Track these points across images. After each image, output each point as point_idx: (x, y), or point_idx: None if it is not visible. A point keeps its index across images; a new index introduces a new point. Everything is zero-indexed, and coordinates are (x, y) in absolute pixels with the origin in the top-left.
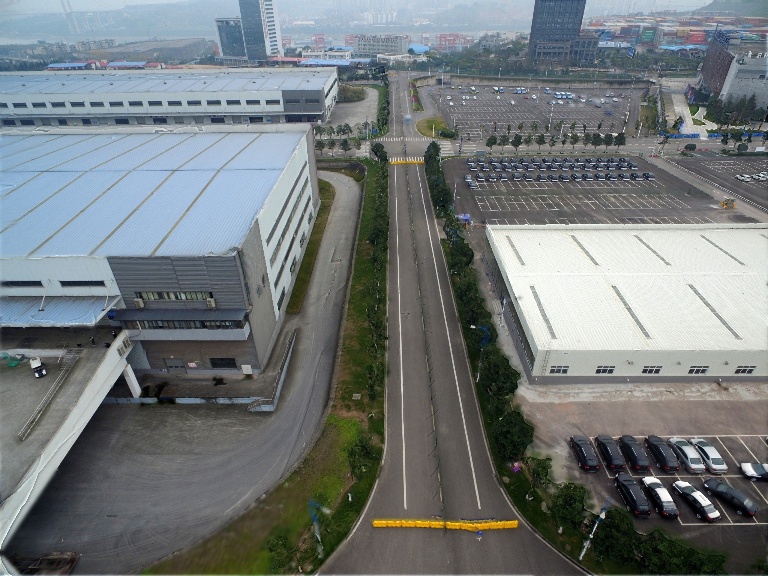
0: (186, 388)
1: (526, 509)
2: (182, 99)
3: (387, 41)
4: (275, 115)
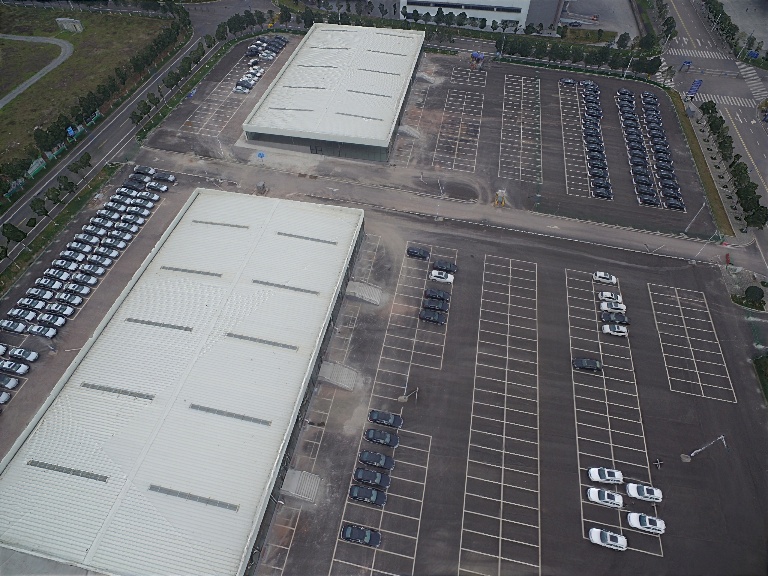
0: (369, 8)
1: None
2: None
3: None
4: None
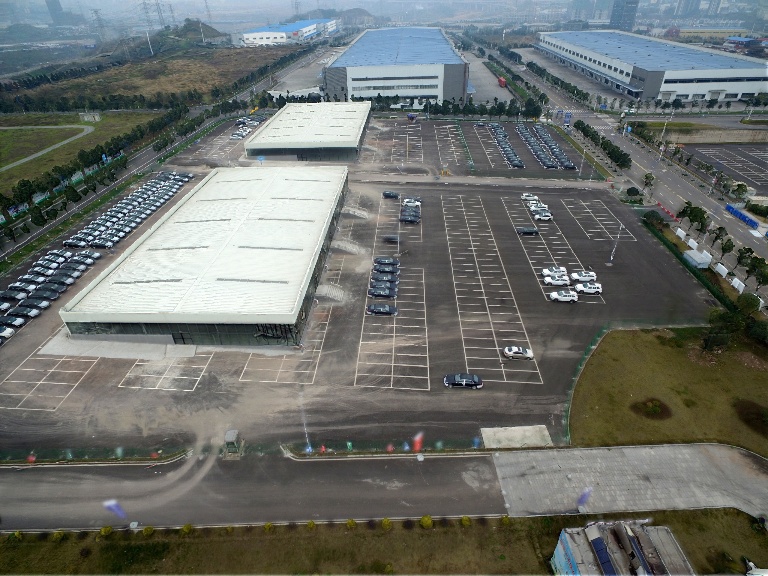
0: None
1: (253, 114)
2: None
3: None
4: None
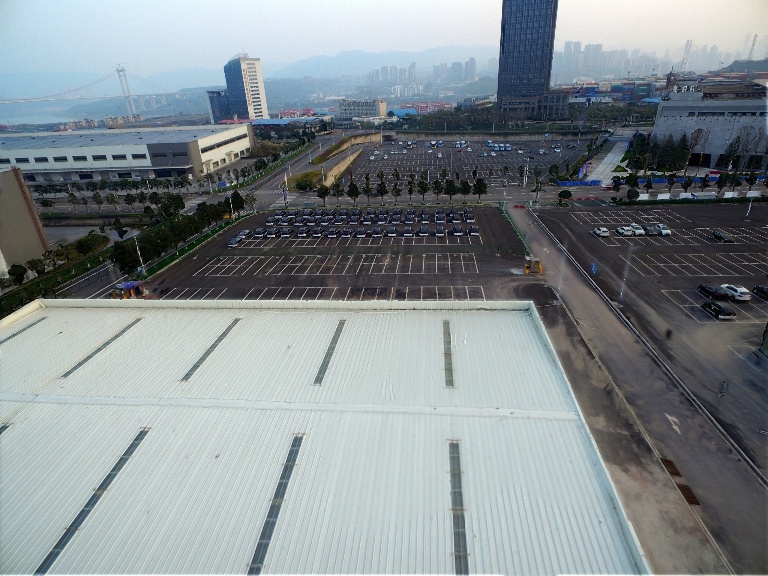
0: None
1: None
2: (48, 155)
3: (366, 105)
4: (142, 170)
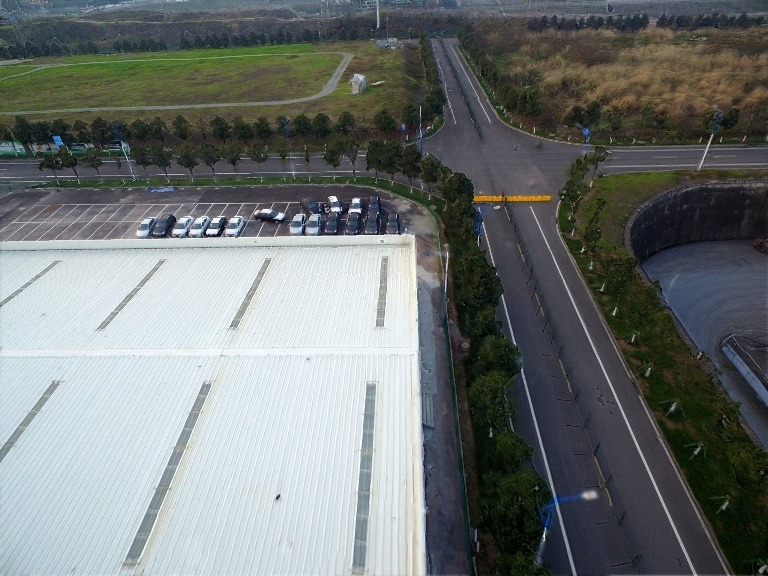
0: None
1: None
2: None
3: None
4: None
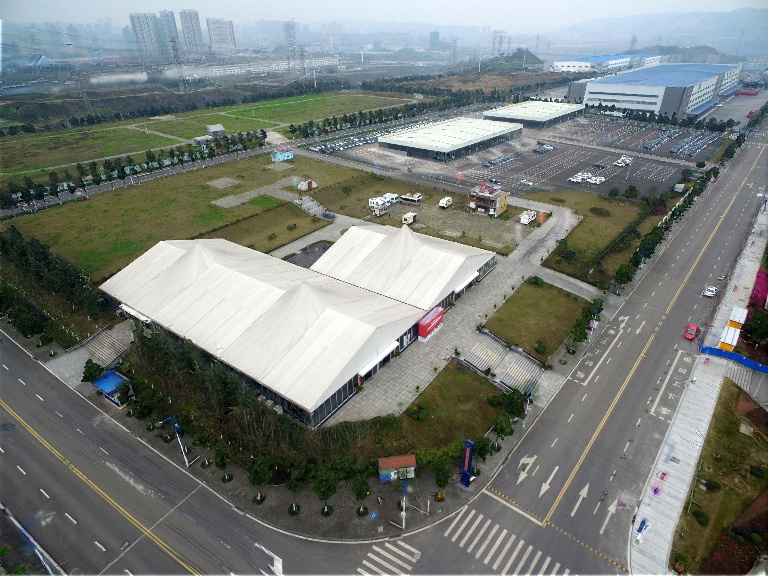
0: None
1: None
2: None
3: None
4: None
